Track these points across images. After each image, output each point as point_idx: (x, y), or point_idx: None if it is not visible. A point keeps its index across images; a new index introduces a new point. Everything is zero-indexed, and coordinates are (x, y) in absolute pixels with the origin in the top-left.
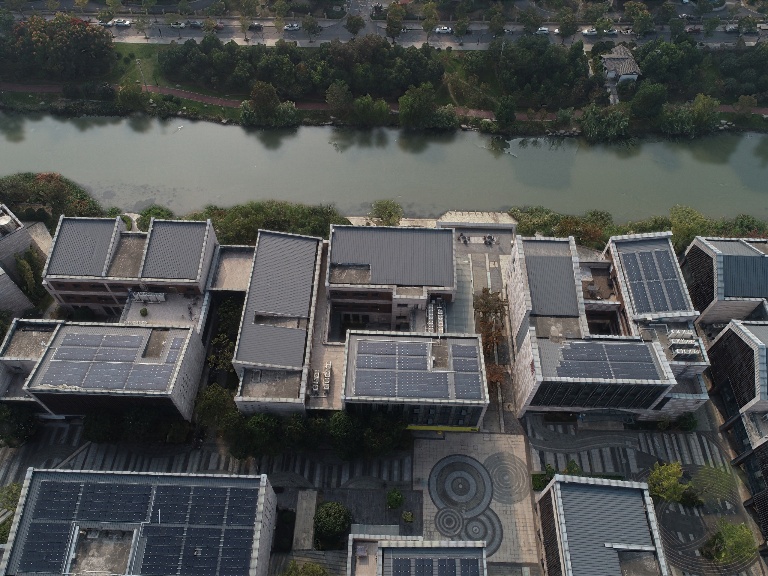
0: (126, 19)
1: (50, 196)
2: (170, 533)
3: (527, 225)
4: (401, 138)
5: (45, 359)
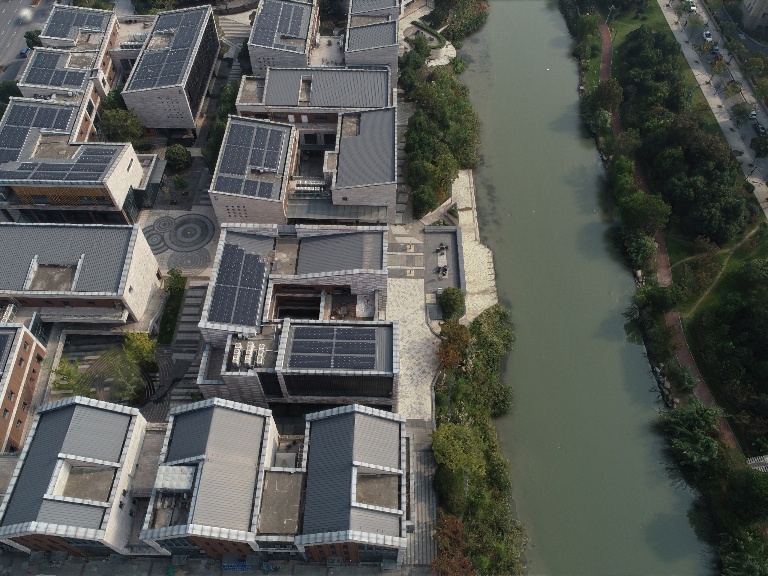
0: (700, 8)
1: None
2: (162, 59)
3: (455, 293)
4: (600, 216)
5: (284, 1)
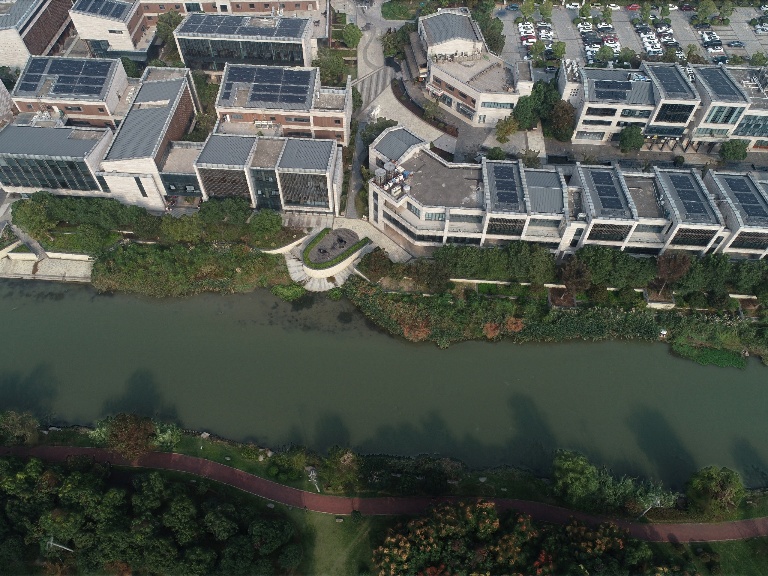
0: None
1: (377, 252)
2: (228, 24)
3: None
4: None
5: None
